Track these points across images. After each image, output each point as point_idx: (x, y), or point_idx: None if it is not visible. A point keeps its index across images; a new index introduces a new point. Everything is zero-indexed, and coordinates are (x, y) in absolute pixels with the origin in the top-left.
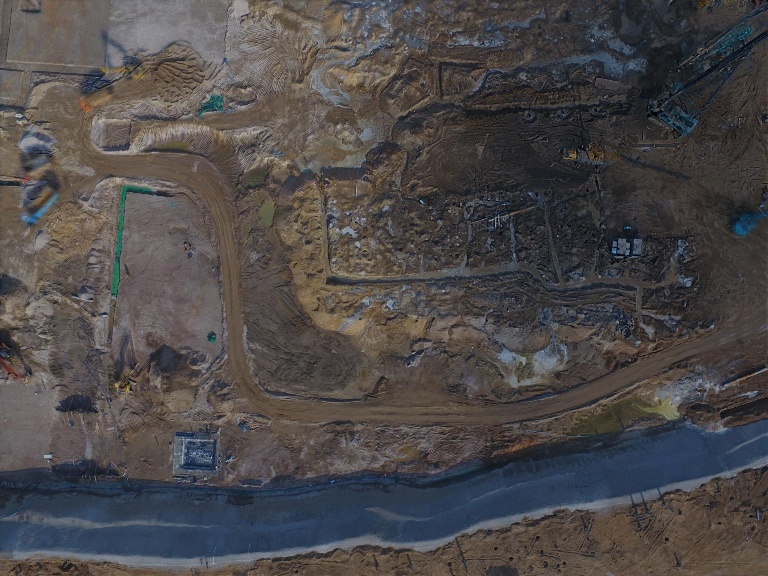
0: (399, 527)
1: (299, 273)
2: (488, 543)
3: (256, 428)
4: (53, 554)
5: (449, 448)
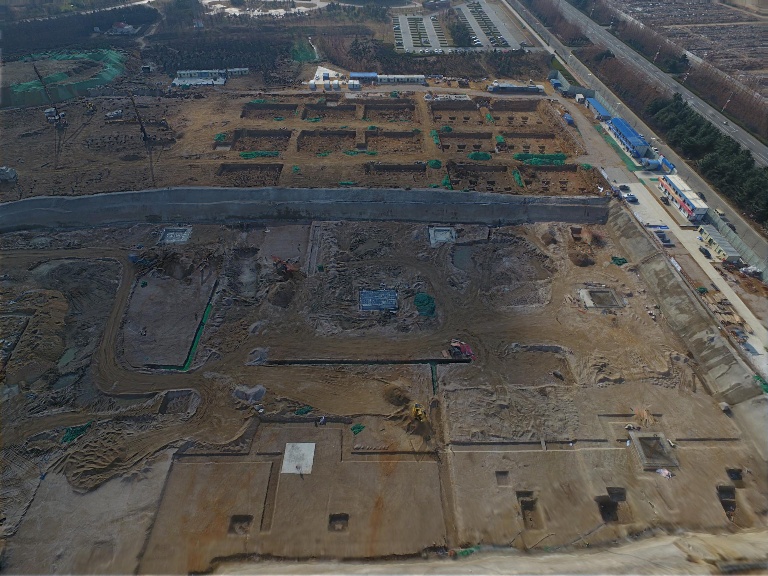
0: (54, 205)
1: (56, 317)
2: (2, 199)
3: (132, 246)
4: (251, 189)
5: (7, 241)
